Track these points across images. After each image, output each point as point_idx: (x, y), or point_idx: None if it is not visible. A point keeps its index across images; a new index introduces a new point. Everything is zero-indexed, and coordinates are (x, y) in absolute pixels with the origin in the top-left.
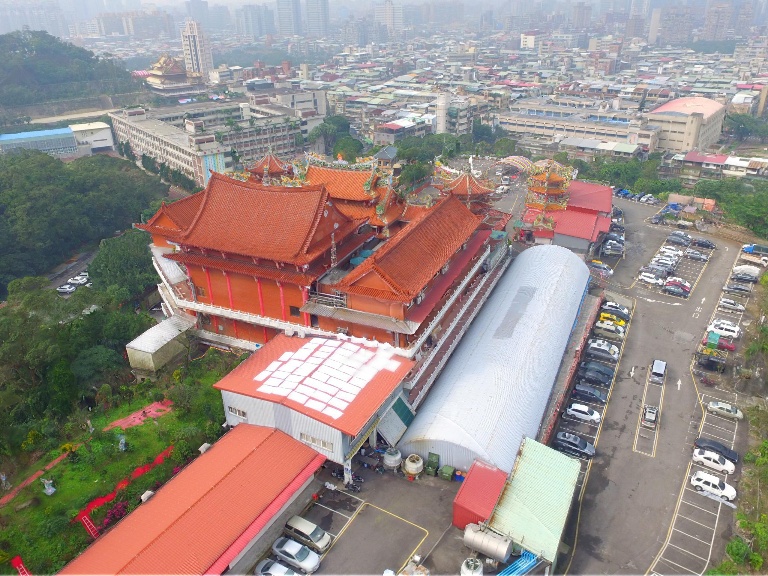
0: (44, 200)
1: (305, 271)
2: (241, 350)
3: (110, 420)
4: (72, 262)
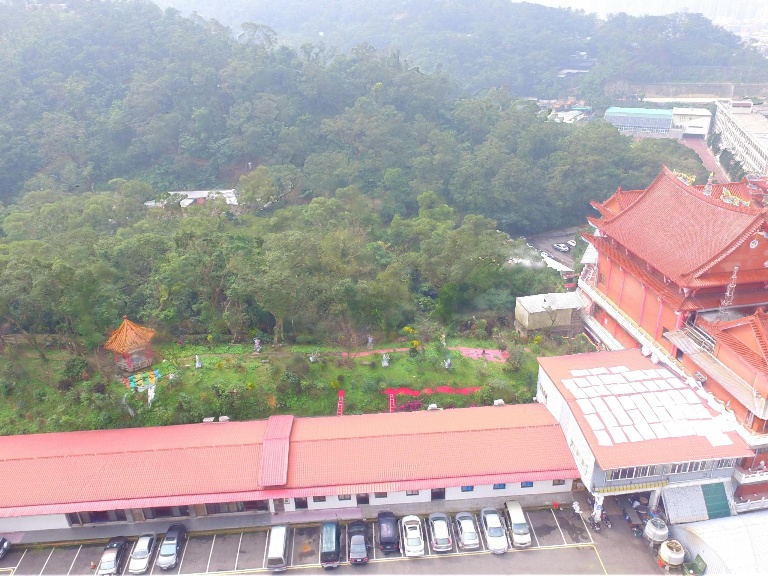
0: (584, 167)
1: (688, 296)
2: (606, 349)
3: (462, 344)
4: None
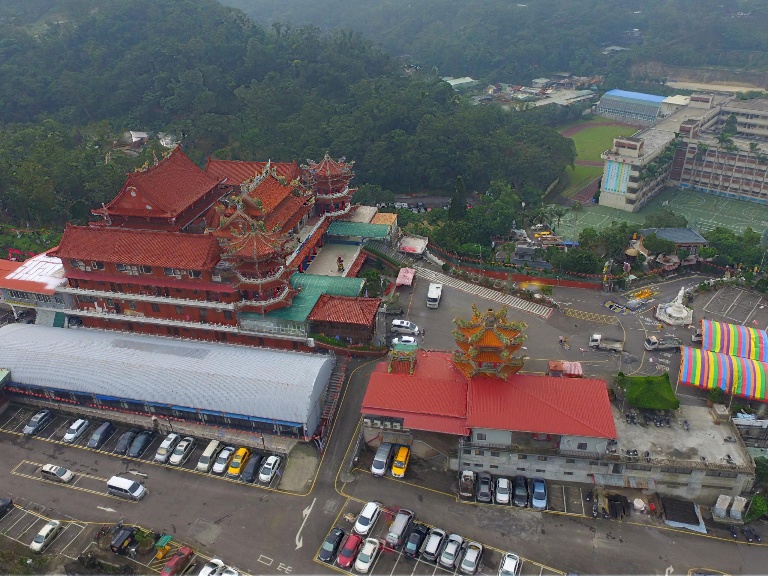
0: (409, 145)
1: None
2: None
3: None
4: (409, 196)
